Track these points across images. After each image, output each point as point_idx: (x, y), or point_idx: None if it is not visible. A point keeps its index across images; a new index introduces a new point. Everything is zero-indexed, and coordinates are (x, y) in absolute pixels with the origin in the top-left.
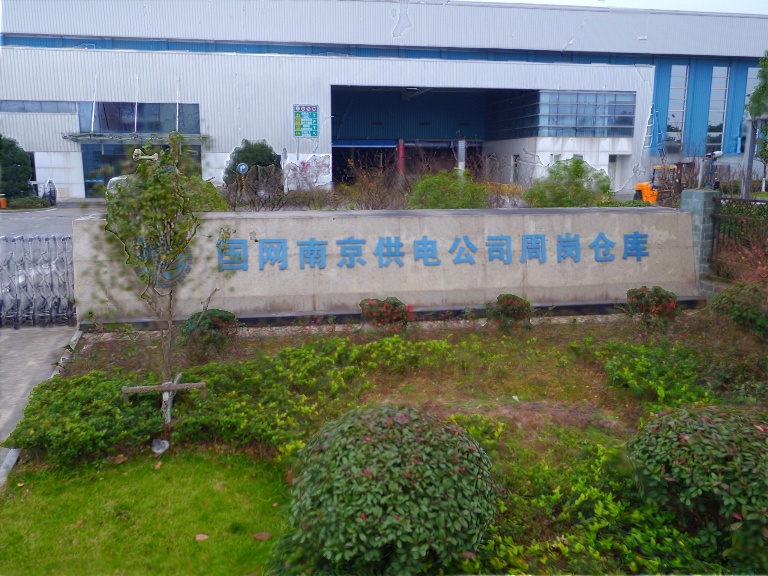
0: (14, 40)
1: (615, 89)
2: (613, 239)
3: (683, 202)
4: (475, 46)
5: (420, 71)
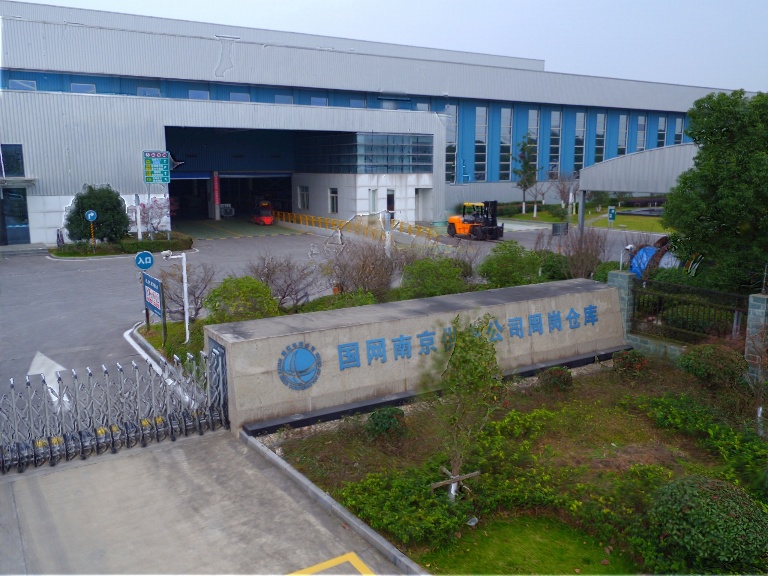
0: None
1: (417, 132)
2: (578, 312)
3: (610, 280)
4: (283, 84)
5: (251, 114)
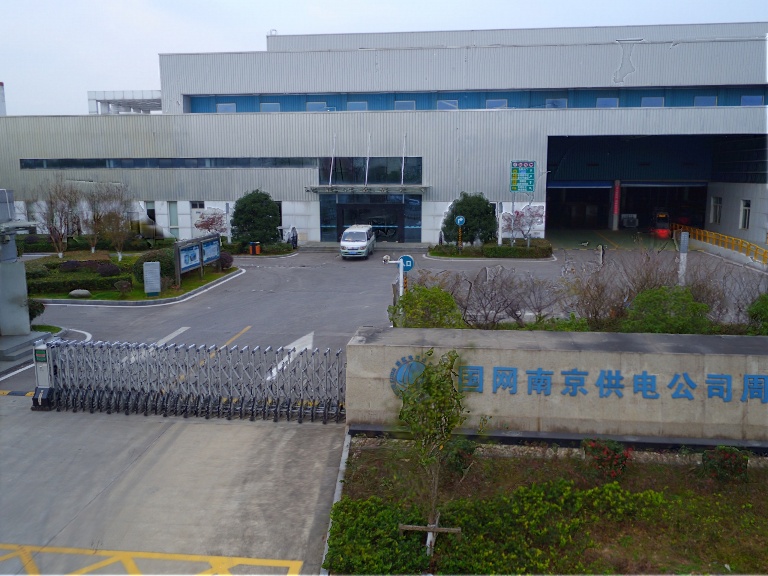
0: (268, 98)
1: None
2: None
3: None
4: (704, 83)
5: (642, 119)
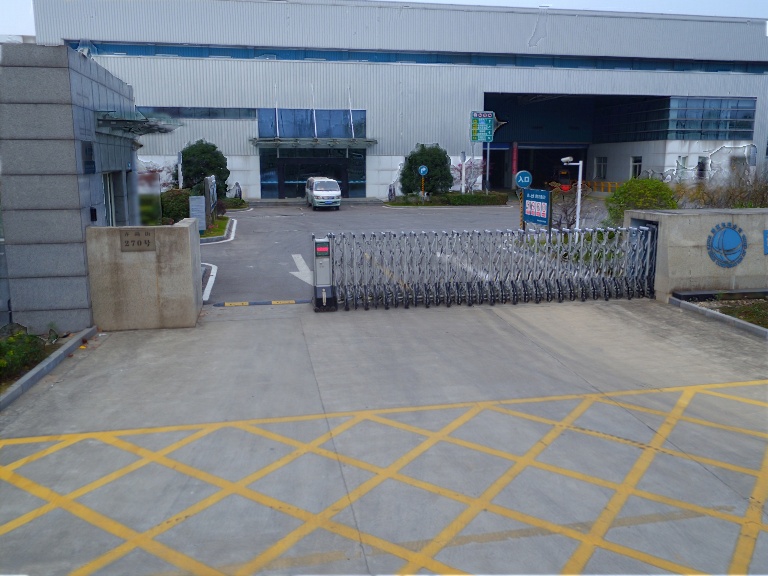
0: (164, 49)
1: (738, 95)
2: None
3: None
4: (588, 54)
5: (564, 79)
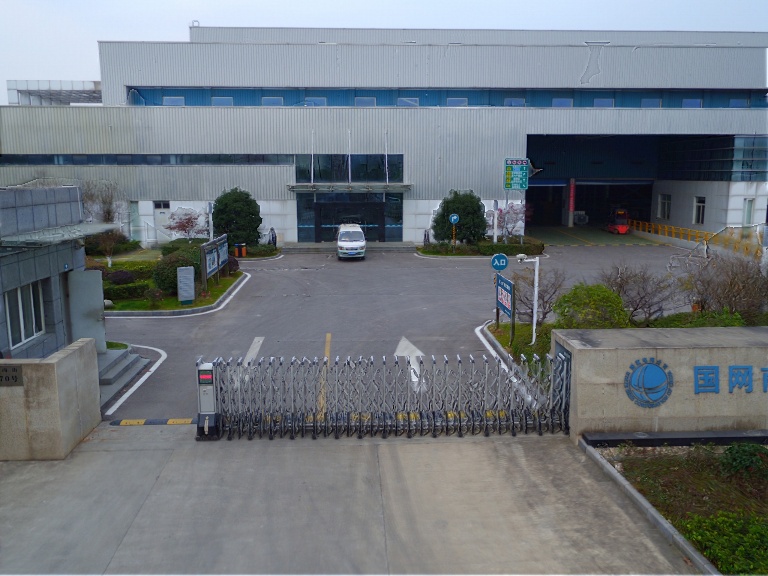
0: (220, 92)
1: None
2: None
3: None
4: (652, 86)
5: (614, 119)
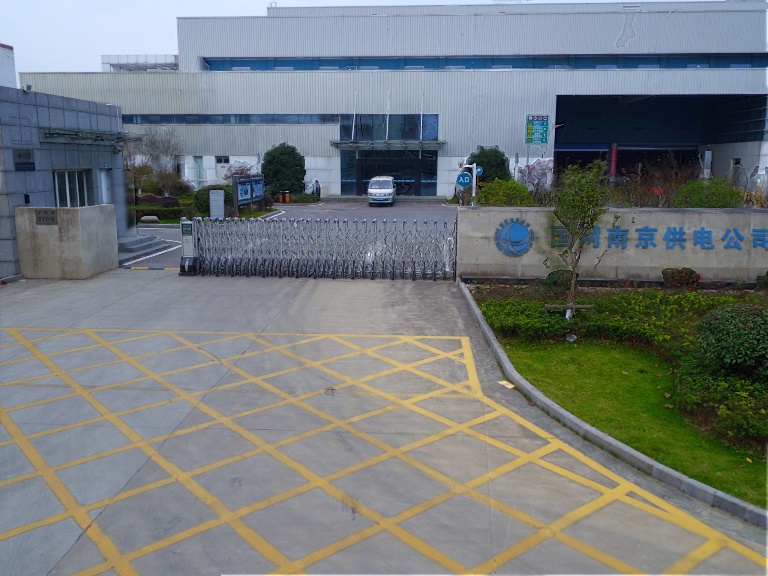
0: (282, 62)
1: None
2: None
3: None
4: (697, 51)
5: (644, 80)
